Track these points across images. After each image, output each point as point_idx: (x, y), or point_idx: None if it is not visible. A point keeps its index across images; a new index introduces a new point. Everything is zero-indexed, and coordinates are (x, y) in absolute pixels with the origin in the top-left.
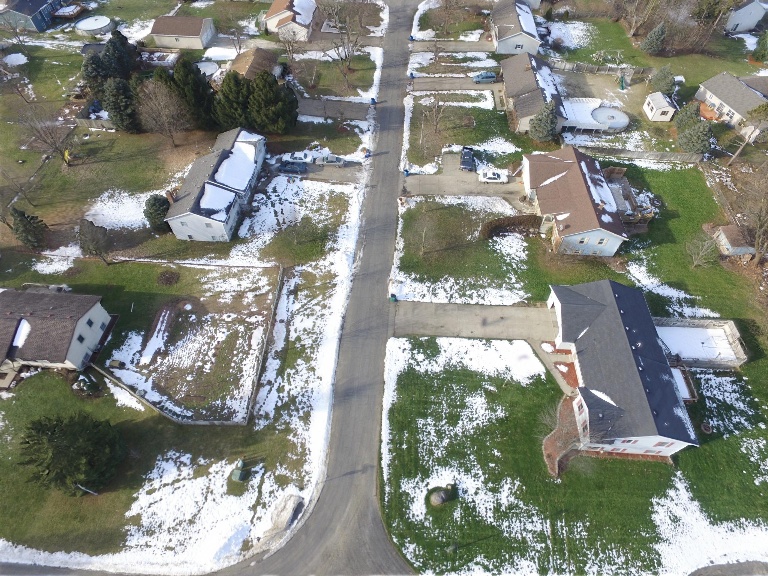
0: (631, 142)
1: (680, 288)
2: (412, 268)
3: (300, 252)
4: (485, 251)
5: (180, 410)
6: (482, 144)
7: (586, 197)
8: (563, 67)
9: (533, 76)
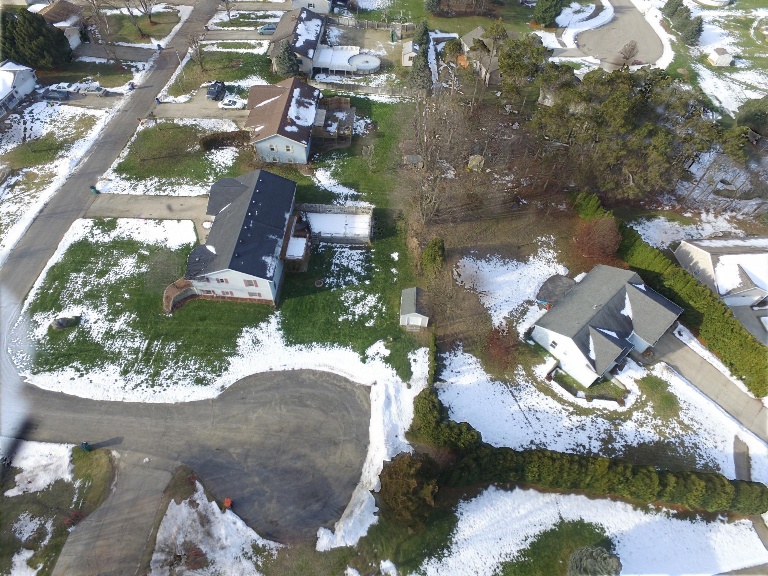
0: (375, 82)
1: (352, 187)
2: (126, 170)
3: (33, 158)
4: (198, 159)
5: None
6: (239, 81)
7: (281, 113)
8: (347, 23)
9: (294, 24)
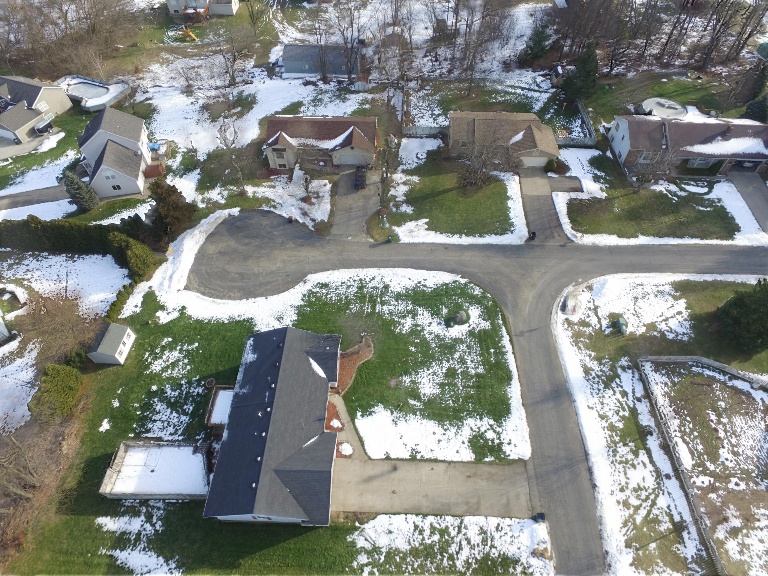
0: None
1: (118, 569)
2: None
3: None
4: None
5: (706, 372)
6: None
7: None
8: None
9: None
